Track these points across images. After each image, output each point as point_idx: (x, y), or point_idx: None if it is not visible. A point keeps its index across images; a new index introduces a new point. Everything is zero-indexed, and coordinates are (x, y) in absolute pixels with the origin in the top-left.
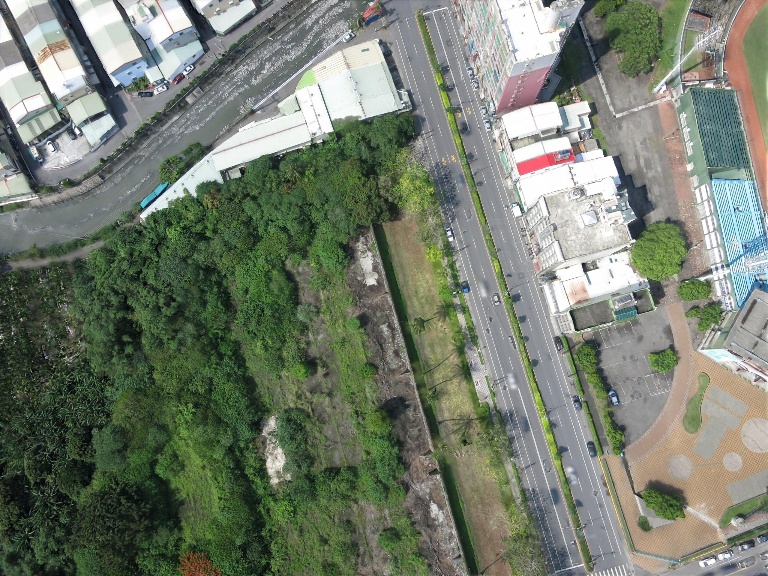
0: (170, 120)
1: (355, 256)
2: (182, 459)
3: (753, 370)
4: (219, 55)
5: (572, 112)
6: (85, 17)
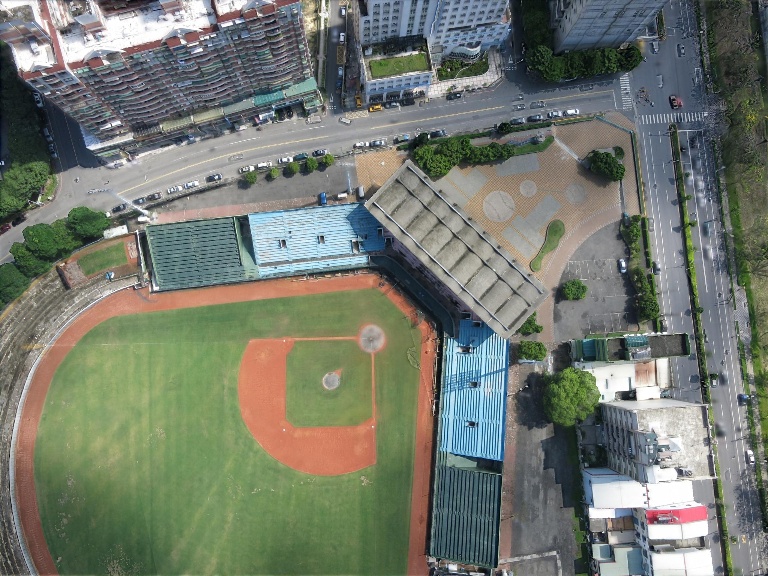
0: None
1: None
2: None
3: None
4: None
5: (621, 567)
6: None
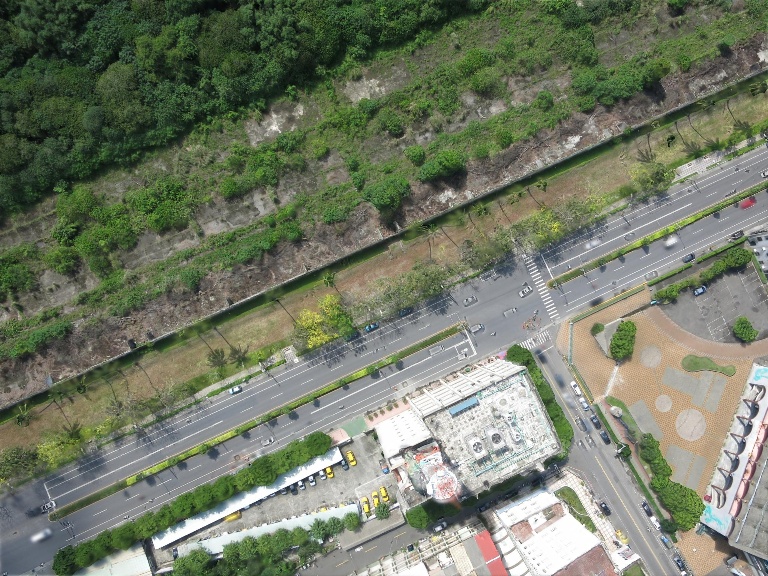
0: None
1: None
2: None
3: (765, 402)
4: None
5: None
6: None
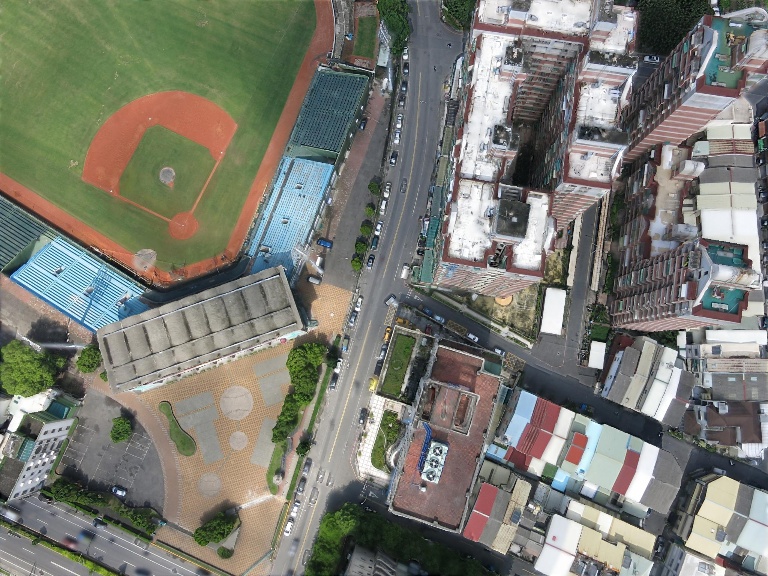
0: None
1: None
2: None
3: None
4: None
5: None
6: None
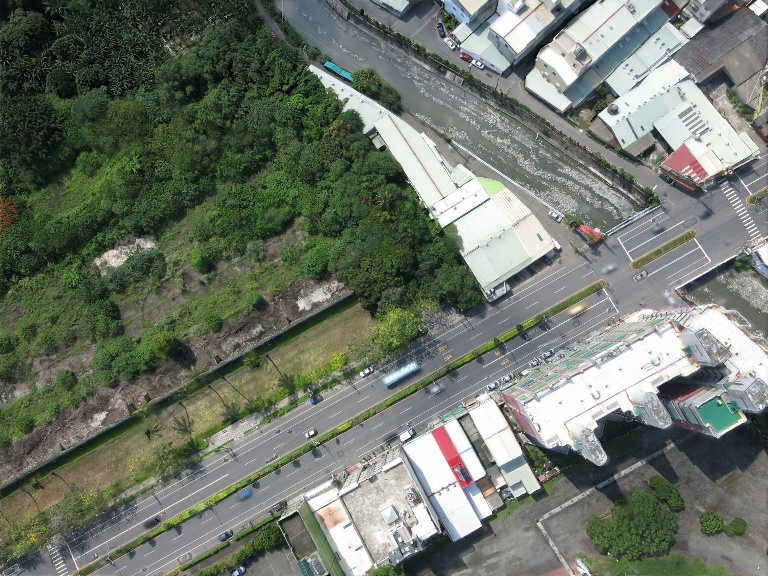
0: (424, 62)
1: (323, 282)
2: (98, 173)
3: None
4: (500, 90)
5: (523, 474)
6: None
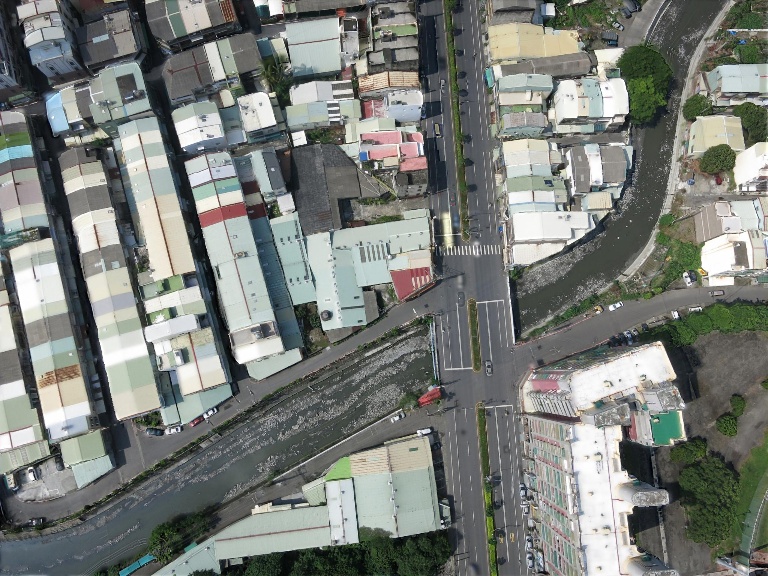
0: (176, 462)
1: None
2: None
3: None
4: None
5: None
6: (106, 343)
